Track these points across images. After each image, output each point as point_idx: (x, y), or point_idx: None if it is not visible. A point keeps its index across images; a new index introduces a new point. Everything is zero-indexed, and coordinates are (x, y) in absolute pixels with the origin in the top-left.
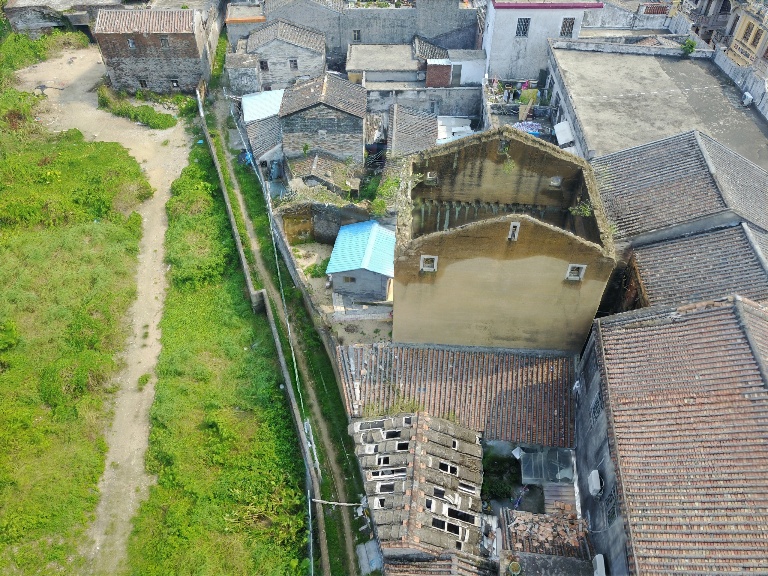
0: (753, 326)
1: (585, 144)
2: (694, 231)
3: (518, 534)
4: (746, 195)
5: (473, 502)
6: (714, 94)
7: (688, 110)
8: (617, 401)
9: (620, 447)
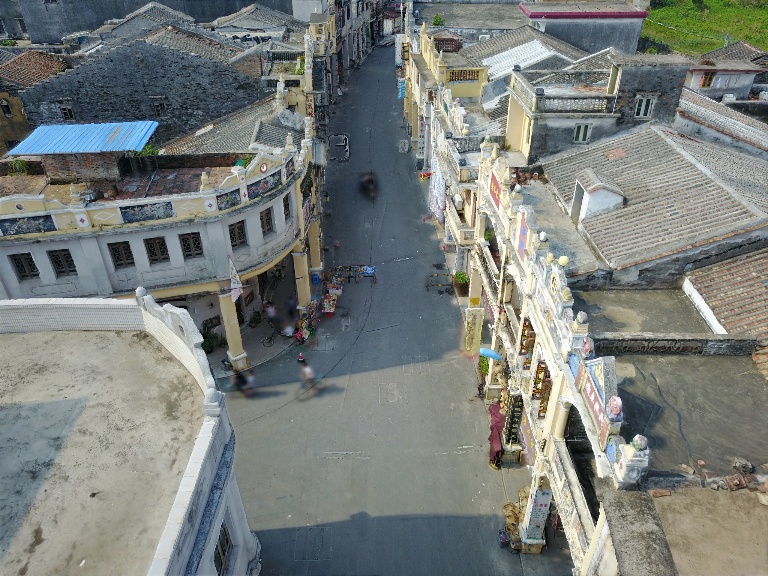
0: None
1: None
2: None
3: None
4: None
5: None
6: None
7: None
8: None
9: None
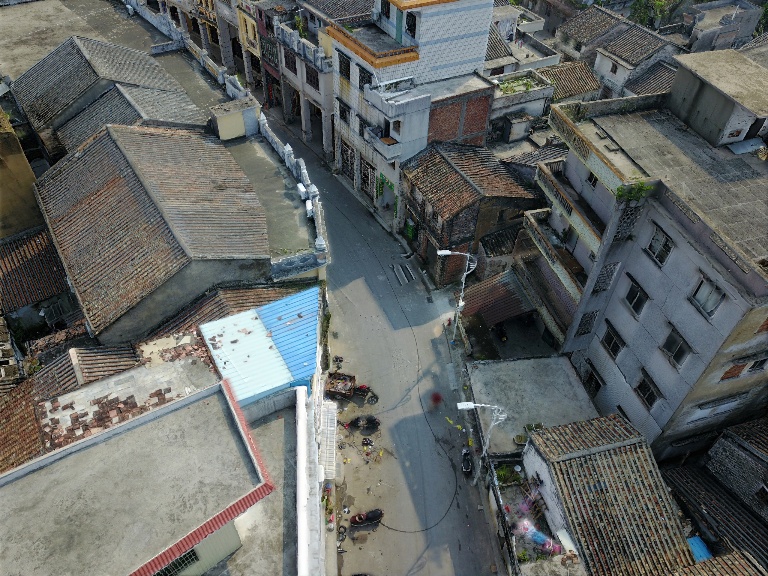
0: (123, 138)
1: (0, 74)
2: (90, 102)
3: (38, 348)
4: (121, 68)
5: (3, 352)
6: (108, 13)
7: (88, 29)
8: (55, 222)
9: (61, 246)
